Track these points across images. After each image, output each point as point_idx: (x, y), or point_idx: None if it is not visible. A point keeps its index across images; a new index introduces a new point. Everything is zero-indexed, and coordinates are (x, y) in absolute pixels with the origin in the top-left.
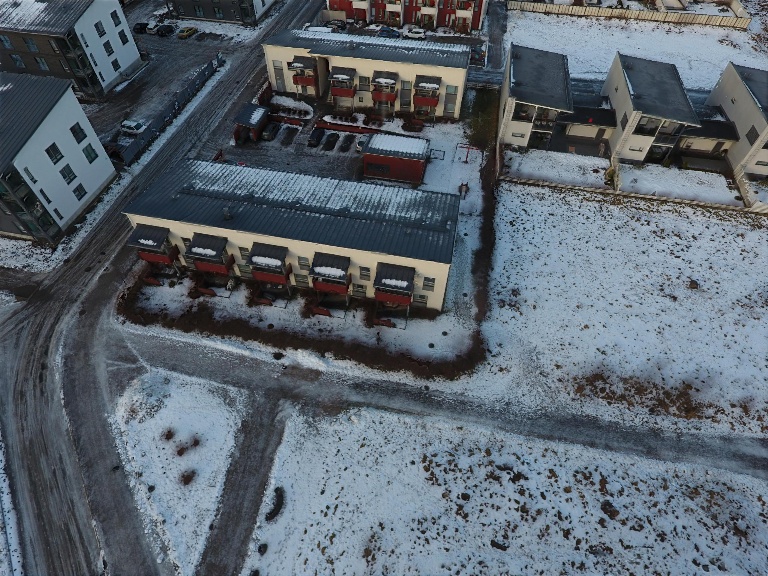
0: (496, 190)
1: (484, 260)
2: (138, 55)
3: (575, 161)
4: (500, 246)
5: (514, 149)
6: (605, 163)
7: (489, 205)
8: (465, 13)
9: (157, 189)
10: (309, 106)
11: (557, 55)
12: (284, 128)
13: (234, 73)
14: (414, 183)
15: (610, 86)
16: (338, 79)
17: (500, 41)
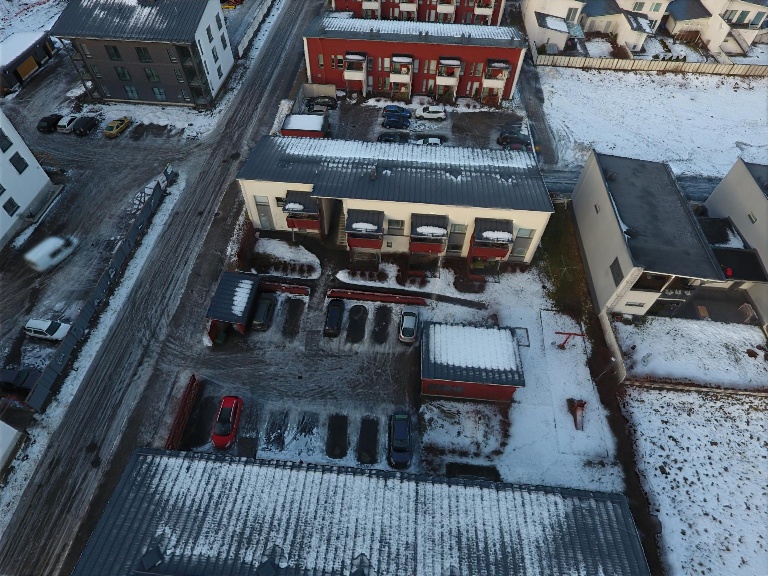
0: (621, 402)
1: (654, 572)
2: (46, 178)
3: (716, 335)
4: (663, 527)
5: (627, 320)
6: (758, 336)
7: (623, 438)
8: (495, 83)
9: (90, 575)
10: (313, 255)
11: (658, 166)
12: (282, 301)
13: (193, 196)
14: (500, 402)
15: (731, 205)
16: (360, 231)
17: (541, 116)
